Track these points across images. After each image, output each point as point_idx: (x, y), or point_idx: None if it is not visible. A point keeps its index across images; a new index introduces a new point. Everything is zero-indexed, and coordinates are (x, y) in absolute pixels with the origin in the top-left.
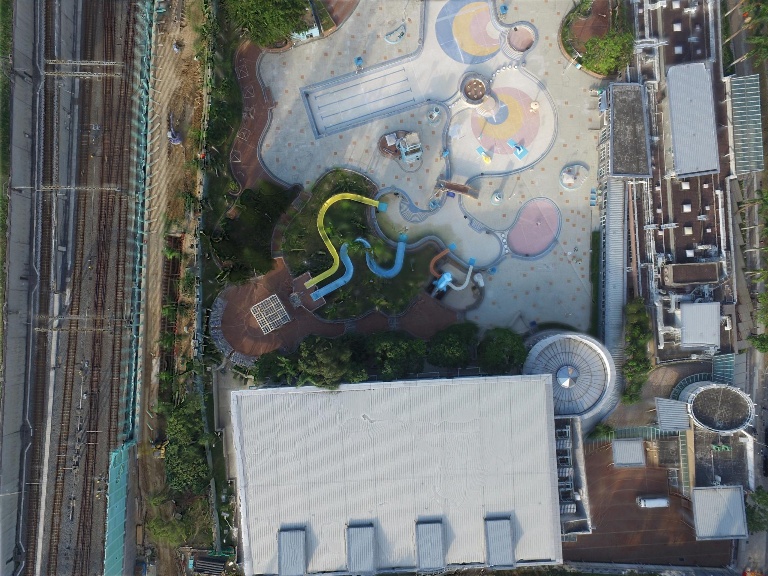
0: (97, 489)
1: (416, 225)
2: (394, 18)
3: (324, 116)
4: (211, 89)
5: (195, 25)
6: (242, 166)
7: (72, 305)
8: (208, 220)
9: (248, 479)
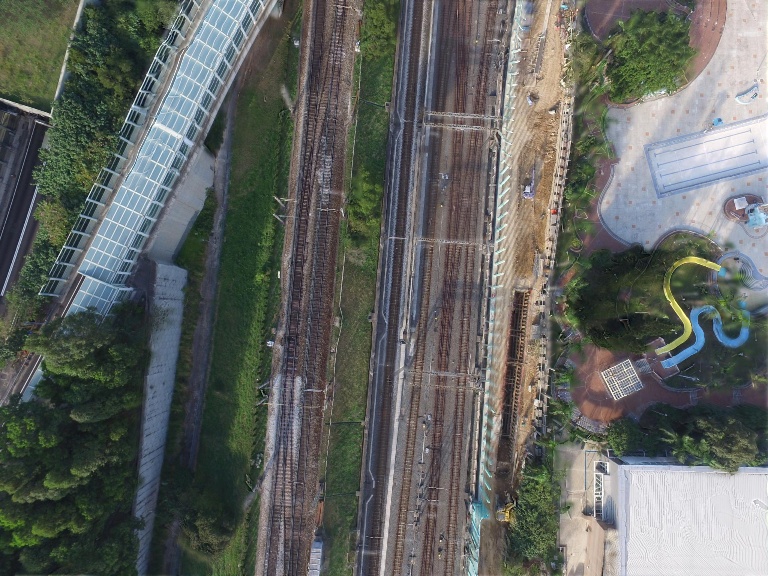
0: (438, 548)
1: (756, 292)
2: (746, 78)
3: (663, 174)
4: (570, 145)
5: (552, 78)
6: (581, 222)
7: (416, 356)
8: (551, 276)
9: (605, 553)
